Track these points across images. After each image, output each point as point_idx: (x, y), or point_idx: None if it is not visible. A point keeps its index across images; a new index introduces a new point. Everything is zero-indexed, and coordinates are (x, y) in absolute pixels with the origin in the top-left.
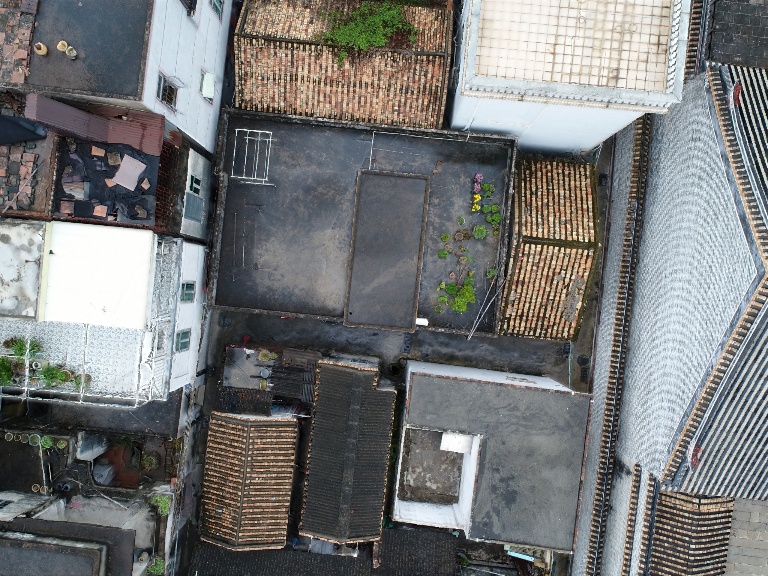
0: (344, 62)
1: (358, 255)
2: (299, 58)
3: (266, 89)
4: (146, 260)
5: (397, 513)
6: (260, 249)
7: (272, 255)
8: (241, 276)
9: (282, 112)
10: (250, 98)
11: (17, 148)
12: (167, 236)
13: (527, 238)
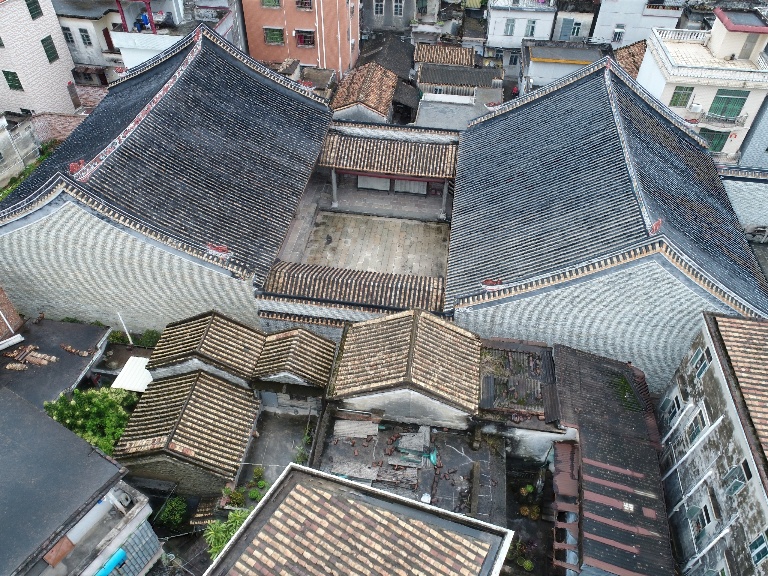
0: None
1: (562, 49)
2: None
3: None
4: None
5: (426, 97)
6: None
7: None
8: None
9: None
10: None
11: None
12: None
13: None
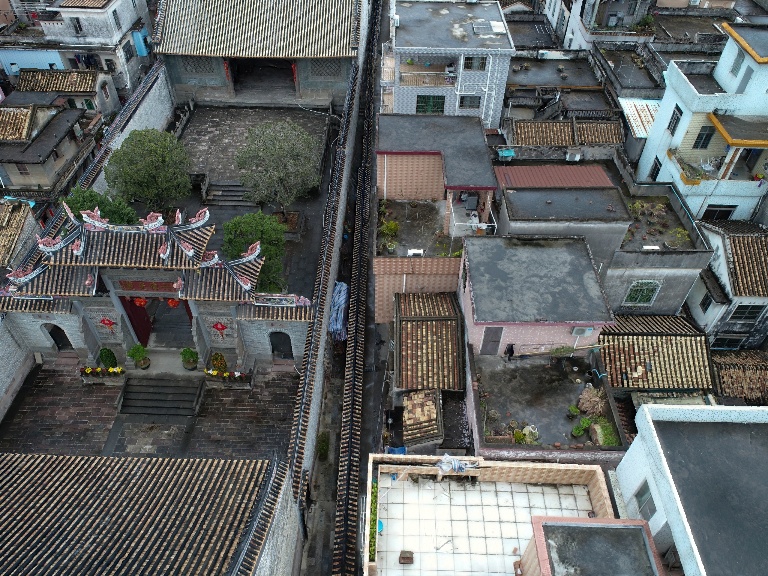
0: None
1: None
2: None
3: None
4: None
5: None
6: None
7: None
8: None
9: None
10: None
11: None
12: None
13: None
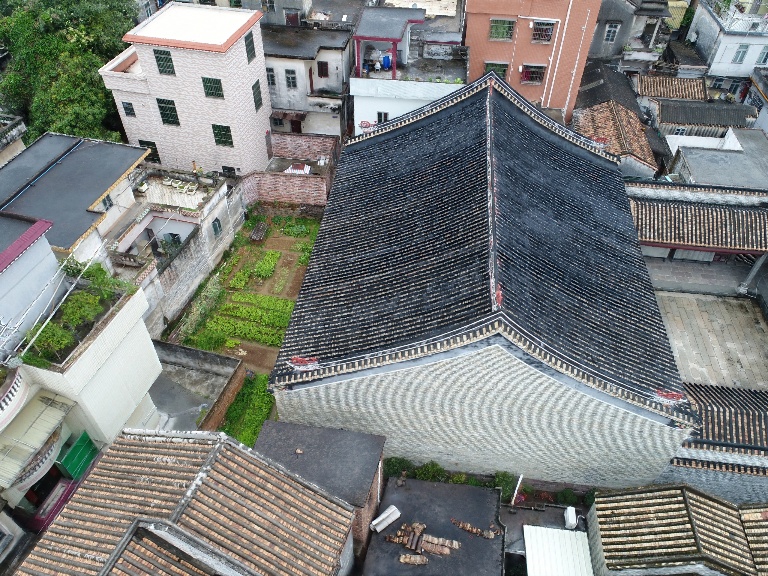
0: None
1: None
2: None
3: None
4: None
5: None
6: None
7: None
8: None
9: None
10: None
11: None
12: None
13: None
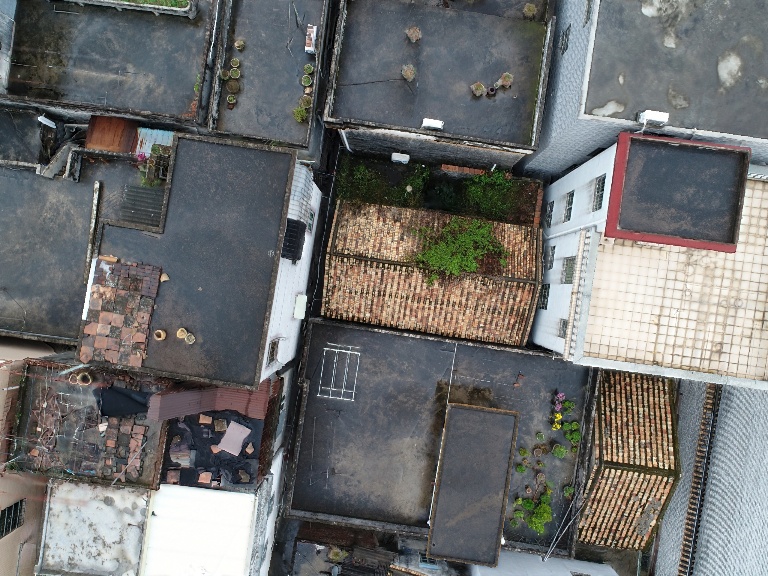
0: (434, 283)
1: (444, 488)
2: (389, 276)
3: (353, 301)
4: (247, 524)
5: None
6: (338, 454)
7: (350, 461)
8: (318, 480)
9: (367, 321)
10: (336, 307)
11: (128, 420)
12: None
13: (608, 464)
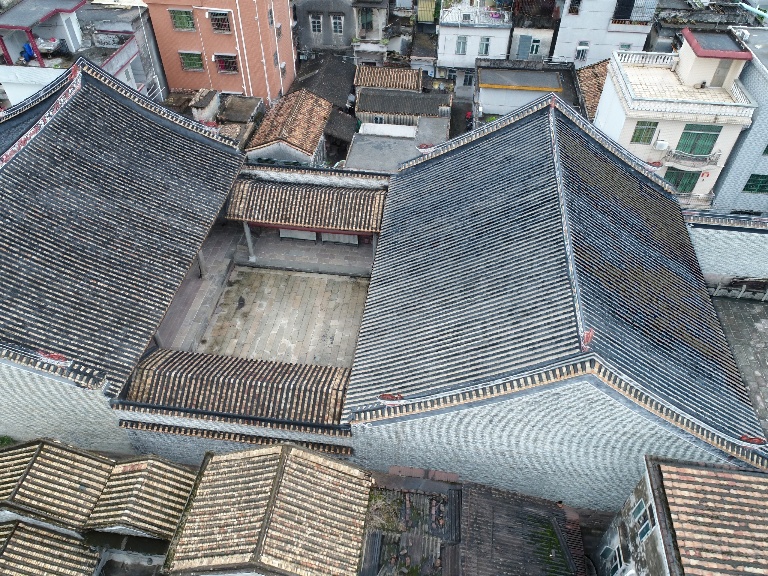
0: None
1: (515, 72)
2: None
3: None
4: None
5: None
6: None
7: None
8: None
9: None
10: None
11: None
12: (512, 22)
13: None
